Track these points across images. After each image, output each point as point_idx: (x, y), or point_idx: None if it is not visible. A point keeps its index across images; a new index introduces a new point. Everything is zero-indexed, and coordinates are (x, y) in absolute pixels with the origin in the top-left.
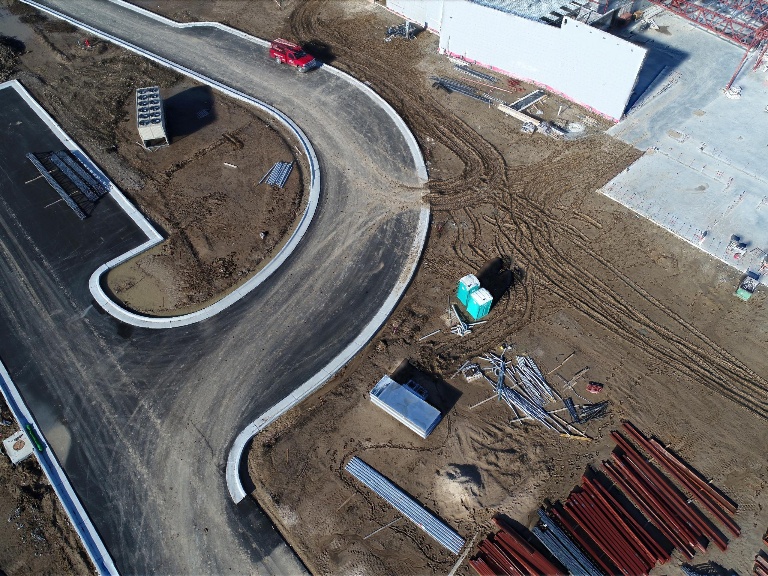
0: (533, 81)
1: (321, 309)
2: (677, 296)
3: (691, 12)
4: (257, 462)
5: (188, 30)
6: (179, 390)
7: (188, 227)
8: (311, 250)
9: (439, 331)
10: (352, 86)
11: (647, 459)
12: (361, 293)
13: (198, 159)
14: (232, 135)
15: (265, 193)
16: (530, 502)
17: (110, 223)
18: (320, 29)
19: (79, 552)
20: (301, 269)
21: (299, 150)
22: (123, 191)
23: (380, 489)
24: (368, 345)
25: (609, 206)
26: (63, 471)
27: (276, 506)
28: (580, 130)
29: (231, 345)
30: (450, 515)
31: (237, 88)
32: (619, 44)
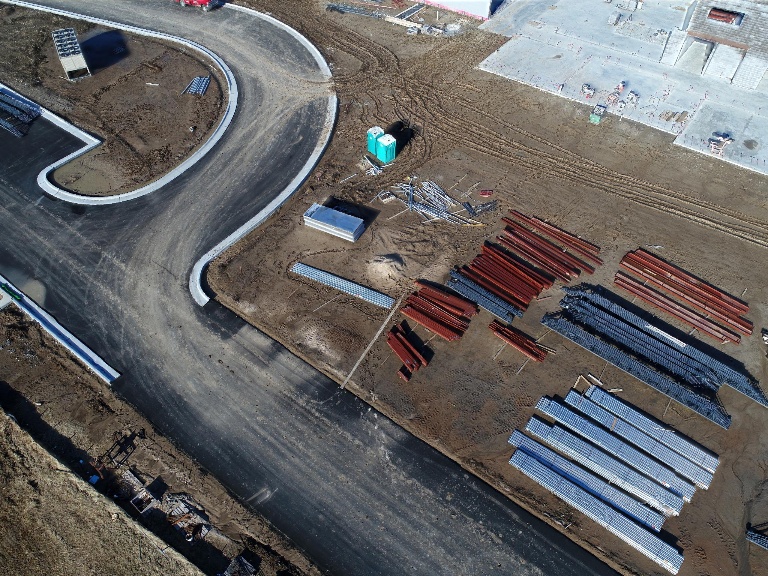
0: None
1: (253, 173)
2: (545, 128)
3: None
4: (215, 278)
5: None
6: (137, 242)
7: (122, 131)
8: (237, 135)
9: (356, 174)
10: (254, 17)
11: (531, 231)
12: (286, 158)
13: (121, 83)
14: (150, 63)
15: (188, 100)
16: (443, 269)
17: (47, 137)
18: None
19: (70, 359)
20: (230, 149)
21: (214, 67)
22: (54, 113)
23: (322, 278)
24: (297, 191)
25: (485, 76)
26: (43, 310)
27: (237, 302)
28: (456, 28)
29: (178, 206)
30: (381, 286)
31: (148, 28)
32: None
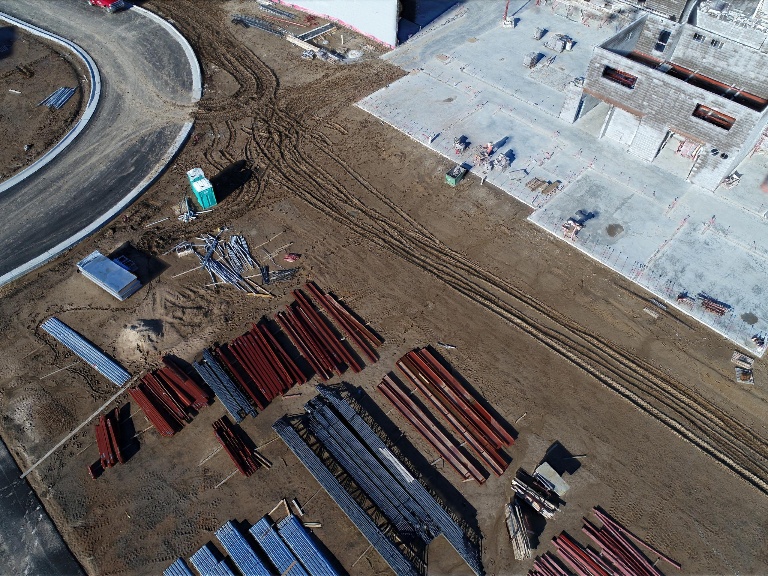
0: (327, 16)
1: (62, 205)
2: (395, 185)
3: None
4: None
5: None
6: None
7: None
8: (69, 158)
9: (167, 219)
10: (155, 24)
11: (318, 309)
12: (105, 191)
13: None
14: (25, 66)
15: (41, 113)
16: (201, 345)
17: None
18: None
19: None
20: (55, 174)
21: (86, 78)
22: None
23: (67, 341)
24: (97, 232)
25: (360, 116)
26: None
27: None
28: (357, 56)
29: None
30: (125, 358)
31: (43, 27)
32: None
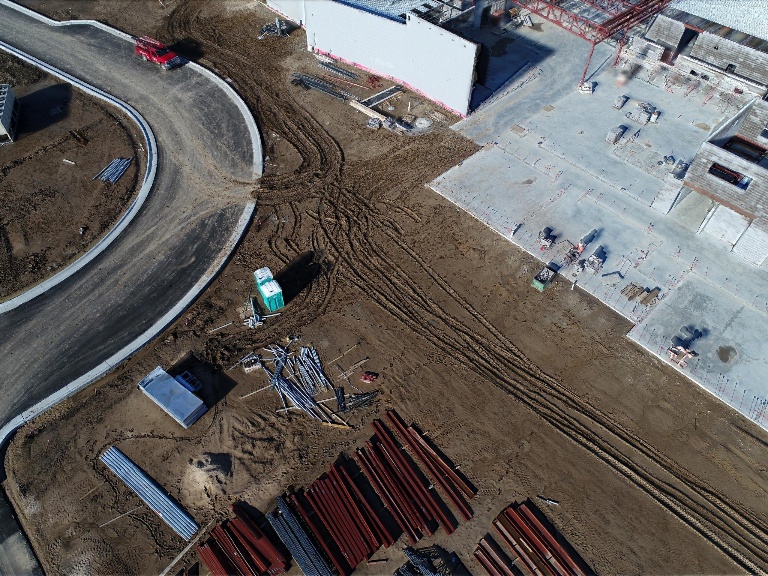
0: (392, 77)
1: (120, 303)
2: (476, 287)
3: (542, 9)
4: (15, 453)
5: (64, 28)
6: None
7: (9, 223)
8: (127, 245)
9: (231, 323)
10: (212, 83)
11: (401, 446)
12: (164, 287)
13: (39, 156)
14: (79, 132)
15: (96, 189)
16: (274, 489)
17: None
18: (196, 27)
19: None
20: (111, 263)
21: (142, 146)
22: None
23: (128, 478)
24: (158, 337)
25: (433, 200)
26: None
27: (21, 496)
28: (426, 125)
29: (21, 339)
30: (191, 503)
31: (97, 85)
32: (454, 40)
